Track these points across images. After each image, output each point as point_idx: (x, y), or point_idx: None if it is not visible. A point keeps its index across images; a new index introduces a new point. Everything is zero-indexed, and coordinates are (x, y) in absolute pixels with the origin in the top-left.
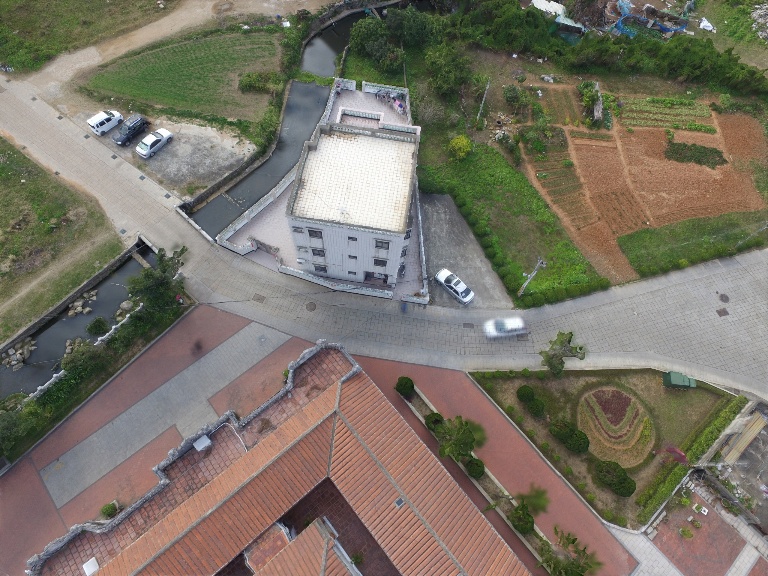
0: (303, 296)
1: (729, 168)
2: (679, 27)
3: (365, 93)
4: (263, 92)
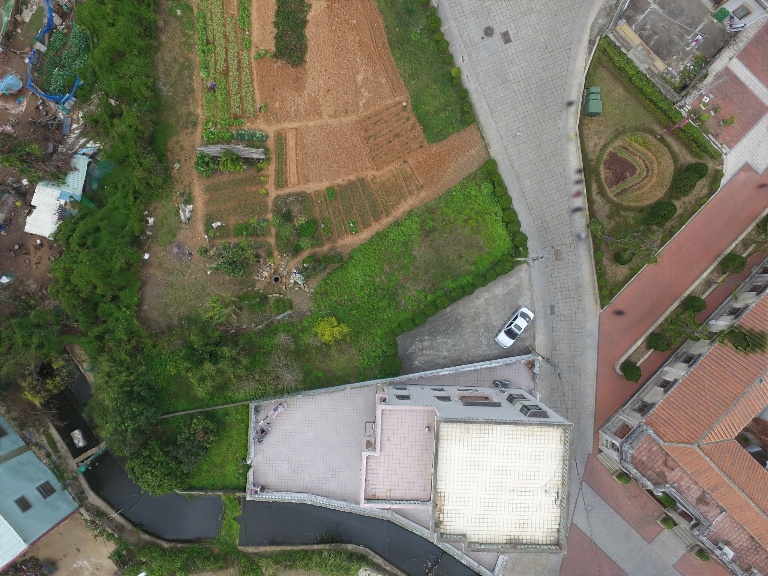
0: None
1: None
2: None
3: (255, 454)
4: None
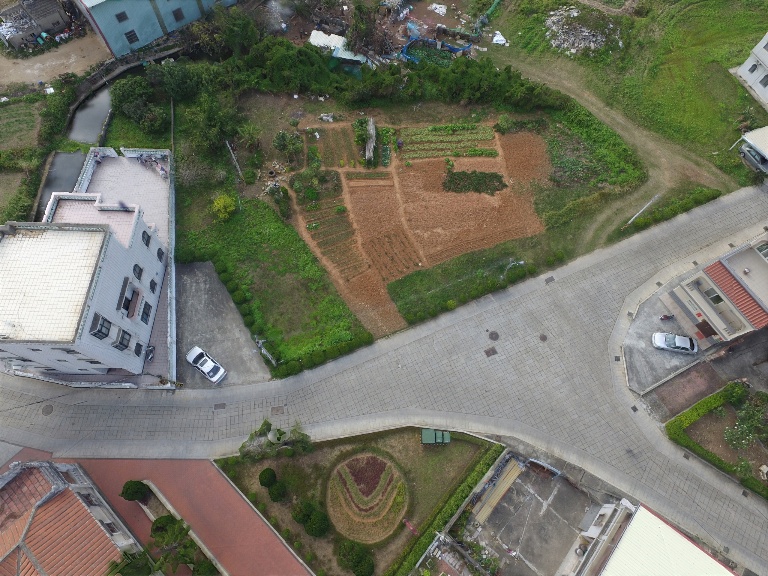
0: (40, 399)
1: (508, 192)
2: (472, 44)
3: (129, 158)
4: (15, 171)
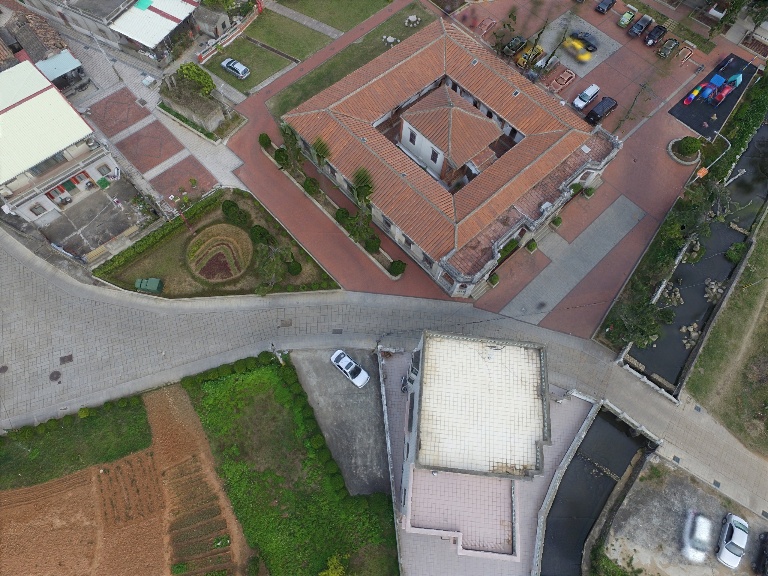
0: None
1: None
2: None
3: None
4: None
